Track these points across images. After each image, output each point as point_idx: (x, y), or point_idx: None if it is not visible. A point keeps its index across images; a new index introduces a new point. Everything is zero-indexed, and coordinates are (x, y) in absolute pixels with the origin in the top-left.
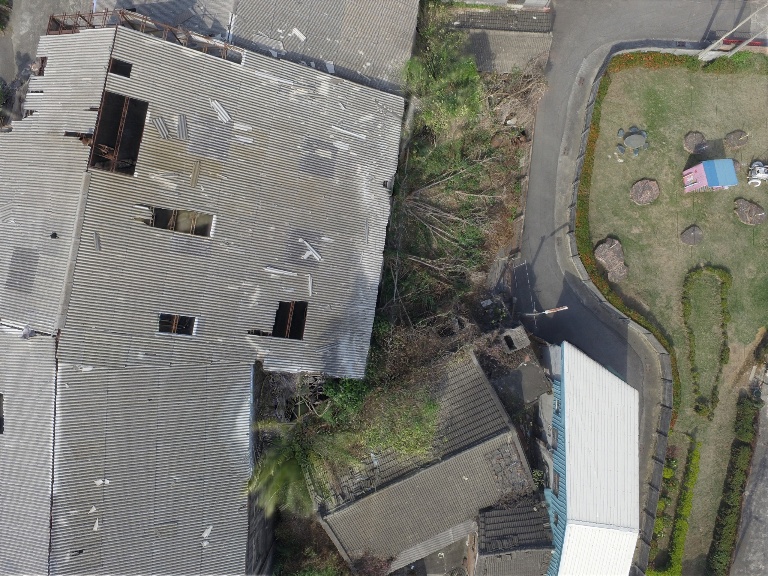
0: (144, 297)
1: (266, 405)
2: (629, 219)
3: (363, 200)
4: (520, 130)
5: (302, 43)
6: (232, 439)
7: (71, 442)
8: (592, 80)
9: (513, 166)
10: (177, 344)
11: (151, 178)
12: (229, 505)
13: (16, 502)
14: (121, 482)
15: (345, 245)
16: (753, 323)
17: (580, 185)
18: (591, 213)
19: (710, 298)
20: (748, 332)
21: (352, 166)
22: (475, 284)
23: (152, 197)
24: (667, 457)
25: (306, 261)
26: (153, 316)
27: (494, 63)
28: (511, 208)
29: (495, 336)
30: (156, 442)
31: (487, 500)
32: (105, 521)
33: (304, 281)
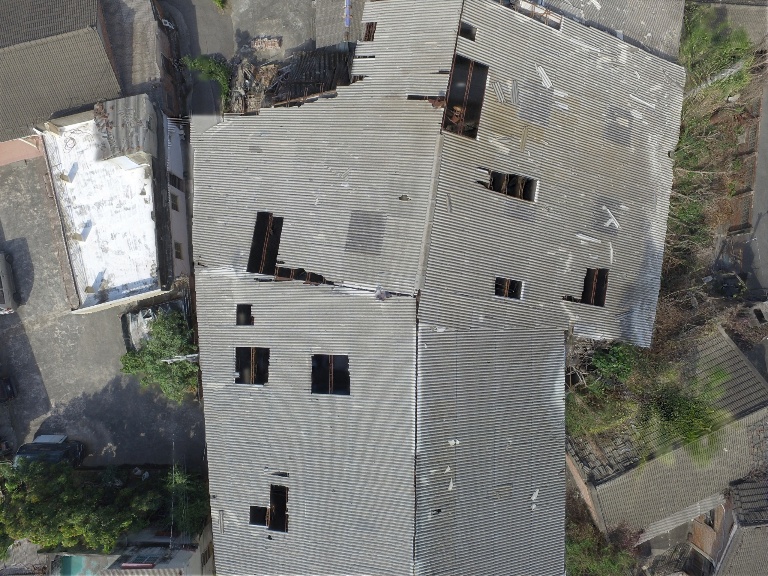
0: (484, 260)
1: None
2: None
3: (652, 169)
4: (741, 107)
5: (598, 12)
6: (552, 404)
7: (430, 402)
8: None
9: (731, 143)
10: (509, 308)
11: (490, 142)
12: (551, 469)
13: (370, 462)
14: (469, 443)
15: (638, 214)
16: None
17: None
18: None
19: None
20: None
21: (644, 135)
22: (699, 260)
23: (491, 161)
24: None
25: (608, 229)
26: (491, 279)
27: (729, 38)
28: (729, 185)
29: (738, 310)
30: (494, 404)
31: (738, 473)
32: (457, 481)
33: (606, 248)
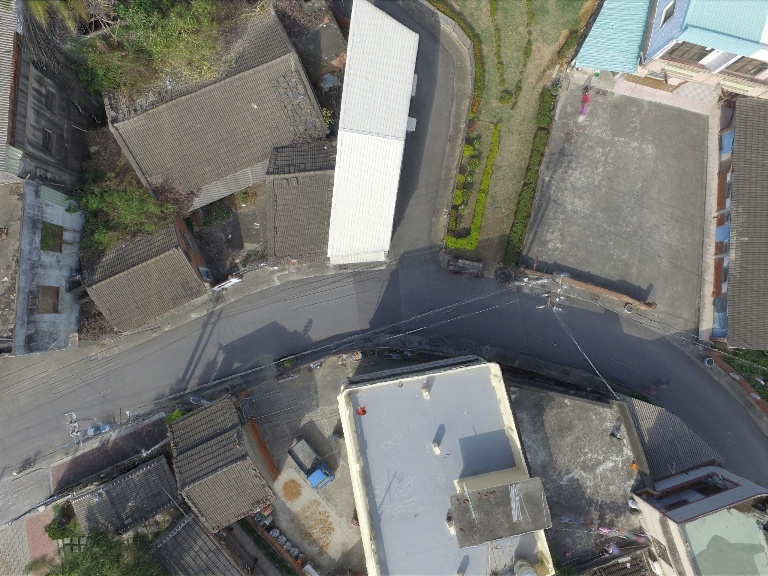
0: None
1: (55, 8)
2: None
3: None
4: None
5: None
6: None
7: None
8: None
9: None
10: None
11: None
12: None
13: None
14: None
15: None
16: (557, 26)
17: None
18: None
19: (517, 1)
20: (552, 34)
21: None
22: None
23: None
24: (468, 135)
25: None
26: None
27: None
28: None
29: None
30: None
31: (281, 138)
32: None
33: None
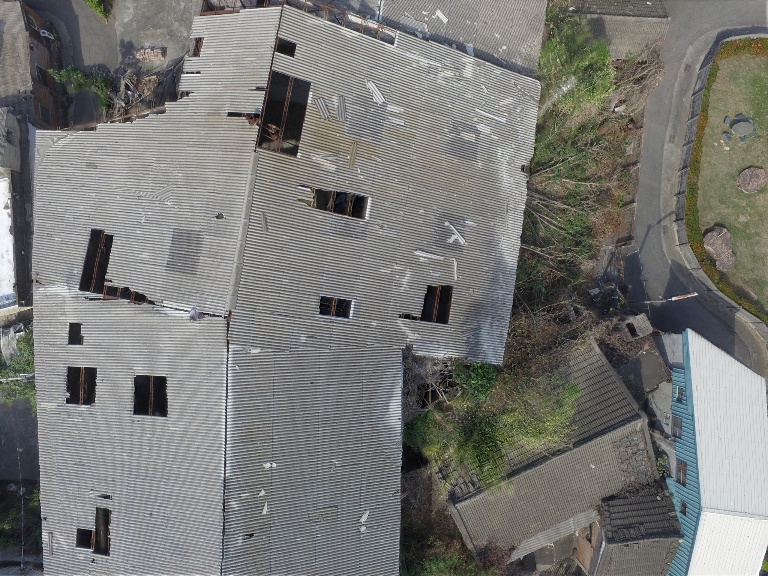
0: (306, 279)
1: None
2: (736, 207)
3: (503, 184)
4: (628, 117)
5: (444, 25)
6: (386, 424)
7: (242, 424)
8: (698, 67)
9: (620, 154)
10: (336, 327)
11: (313, 159)
12: (384, 490)
13: (184, 485)
14: (287, 465)
15: (487, 229)
16: None
17: (689, 173)
18: (697, 201)
19: None
20: None
21: (493, 149)
22: (584, 272)
23: (314, 178)
24: None
25: (452, 245)
26: (314, 298)
27: (609, 49)
28: (617, 196)
29: (614, 324)
30: (318, 426)
31: (610, 489)
32: (273, 505)
33: (450, 265)
